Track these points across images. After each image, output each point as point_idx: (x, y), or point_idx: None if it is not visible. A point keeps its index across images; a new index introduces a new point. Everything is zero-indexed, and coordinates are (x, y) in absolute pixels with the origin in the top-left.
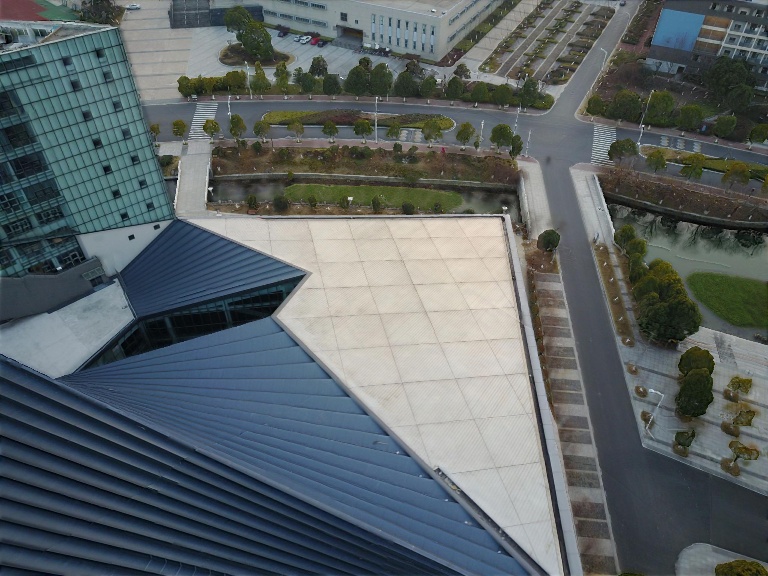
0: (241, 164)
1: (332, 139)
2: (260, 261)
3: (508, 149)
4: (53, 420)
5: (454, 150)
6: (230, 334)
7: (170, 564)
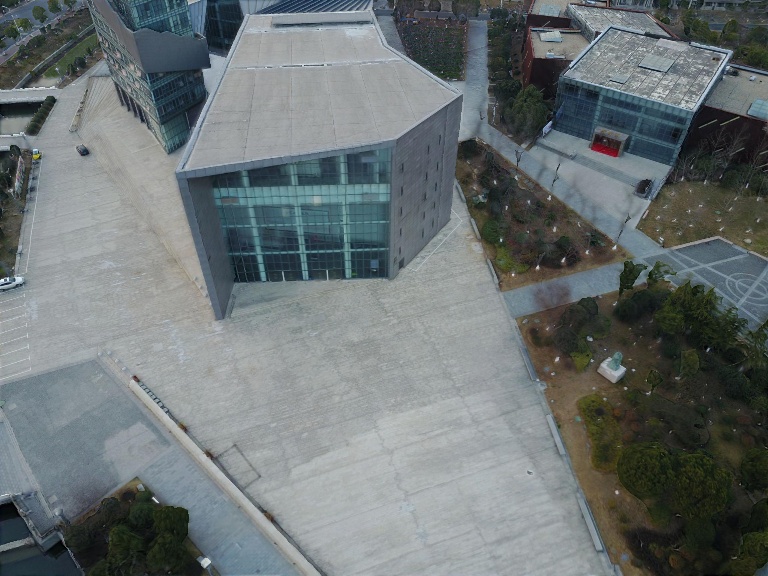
0: (2, 85)
1: (3, 53)
2: (190, 8)
3: (75, 6)
4: (290, 5)
5: (57, 22)
6: (244, 4)
7: (344, 0)
